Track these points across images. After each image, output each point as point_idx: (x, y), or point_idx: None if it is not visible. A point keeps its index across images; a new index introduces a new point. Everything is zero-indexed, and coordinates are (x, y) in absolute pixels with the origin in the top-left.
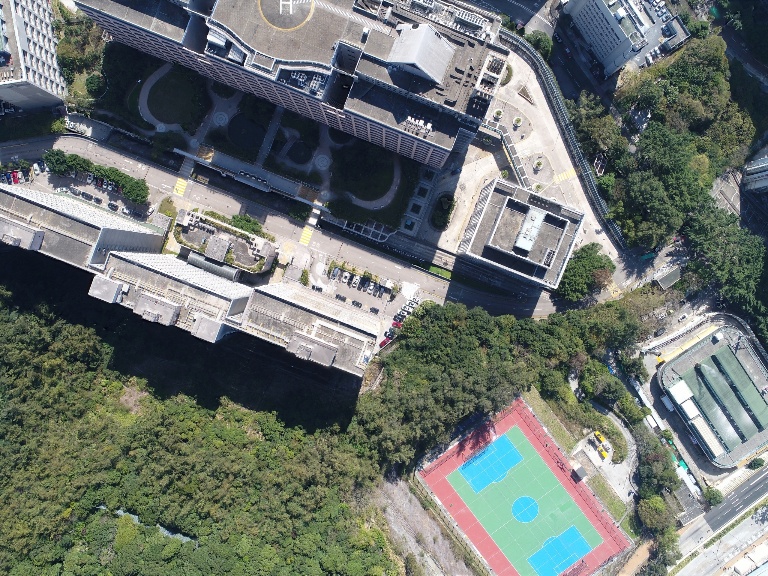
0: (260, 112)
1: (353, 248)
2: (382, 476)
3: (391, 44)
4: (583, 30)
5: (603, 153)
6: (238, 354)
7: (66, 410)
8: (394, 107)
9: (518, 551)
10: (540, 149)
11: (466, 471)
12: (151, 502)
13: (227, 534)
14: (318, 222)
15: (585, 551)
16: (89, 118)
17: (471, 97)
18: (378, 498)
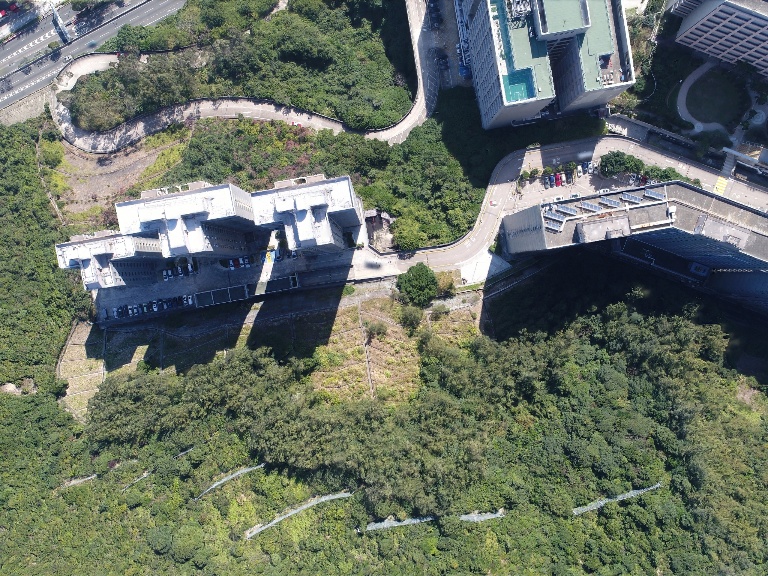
0: None
1: None
2: None
3: None
4: None
5: None
6: None
7: None
8: None
9: None
10: None
11: None
12: None
13: None
14: None
15: None
16: (627, 119)
17: None
18: None
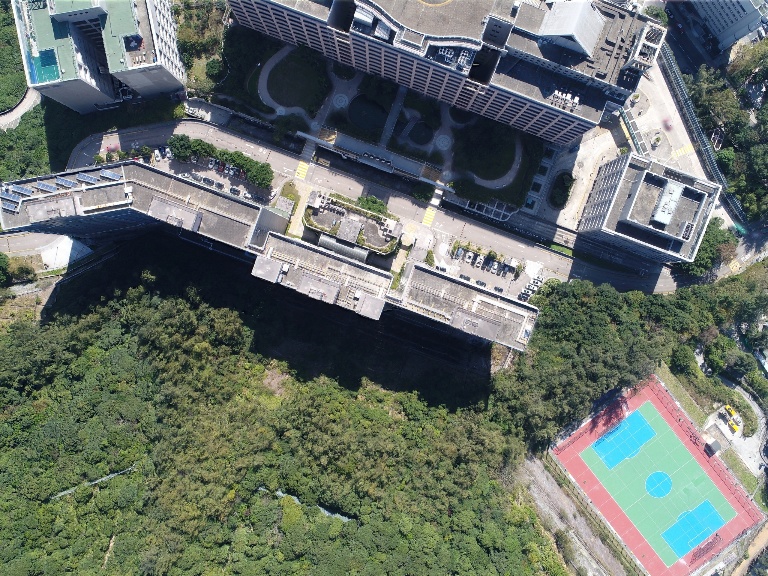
0: (385, 92)
1: (476, 228)
2: (523, 453)
3: (542, 17)
4: (698, 4)
5: (720, 128)
6: (370, 336)
7: (216, 393)
8: (540, 81)
9: (652, 526)
10: (658, 125)
11: (599, 448)
12: (311, 482)
13: (389, 512)
14: (441, 202)
15: (719, 525)
16: (208, 103)
17: (622, 69)
18: (521, 475)
